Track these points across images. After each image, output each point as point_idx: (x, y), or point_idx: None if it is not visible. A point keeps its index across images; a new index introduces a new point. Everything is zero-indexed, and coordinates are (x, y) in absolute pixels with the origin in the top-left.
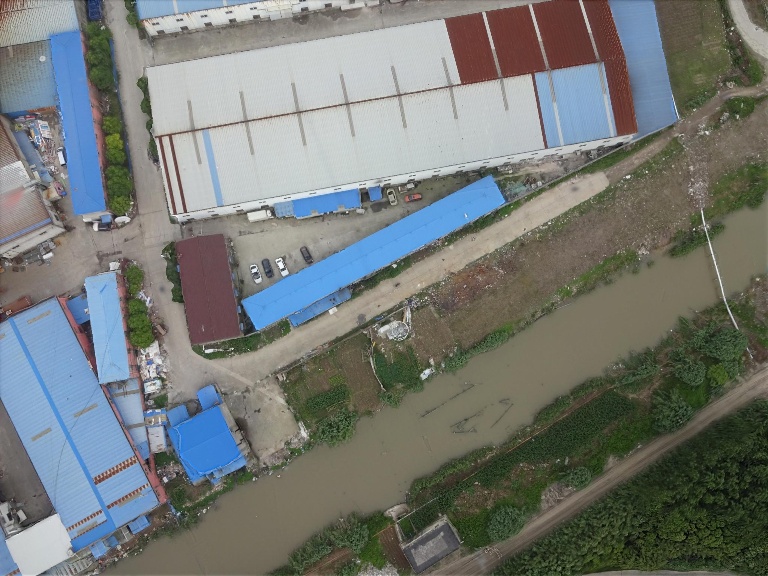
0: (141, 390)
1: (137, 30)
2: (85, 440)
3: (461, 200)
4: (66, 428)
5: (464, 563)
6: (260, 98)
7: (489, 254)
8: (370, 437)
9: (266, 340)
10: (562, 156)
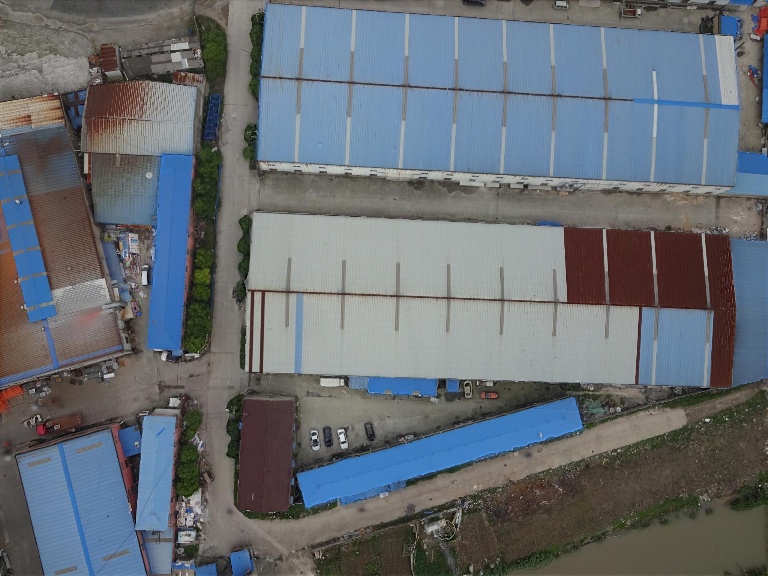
0: (174, 539)
1: (249, 158)
2: None
3: (539, 417)
4: (92, 571)
5: None
6: (362, 272)
7: (552, 469)
8: None
9: (310, 510)
10: None
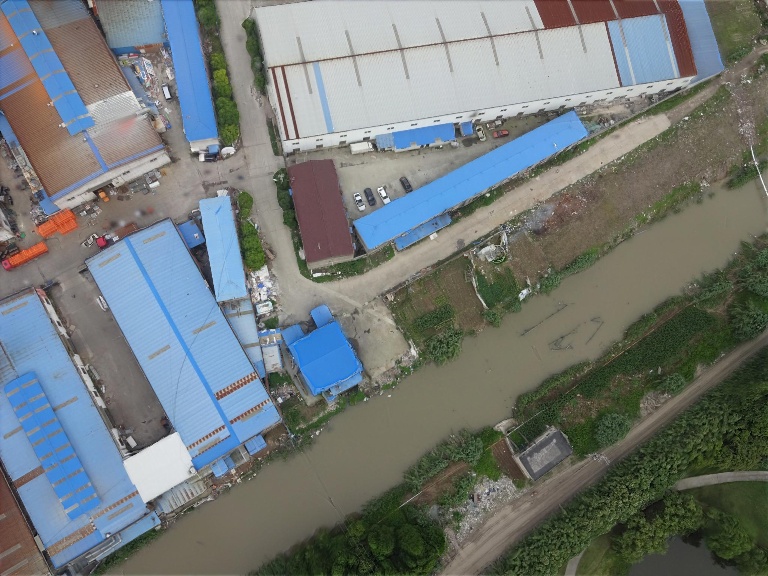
0: (254, 311)
1: None
2: (205, 356)
3: (550, 131)
4: (186, 344)
5: (575, 470)
6: (364, 36)
7: (572, 185)
8: (475, 355)
9: (372, 264)
10: (629, 99)
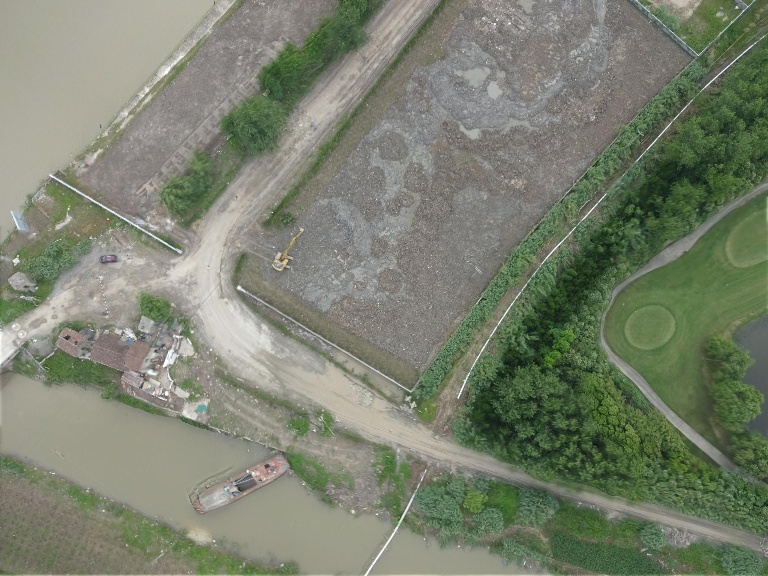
0: None
1: None
2: None
3: None
4: None
5: None
6: None
7: None
8: None
9: None
10: None
